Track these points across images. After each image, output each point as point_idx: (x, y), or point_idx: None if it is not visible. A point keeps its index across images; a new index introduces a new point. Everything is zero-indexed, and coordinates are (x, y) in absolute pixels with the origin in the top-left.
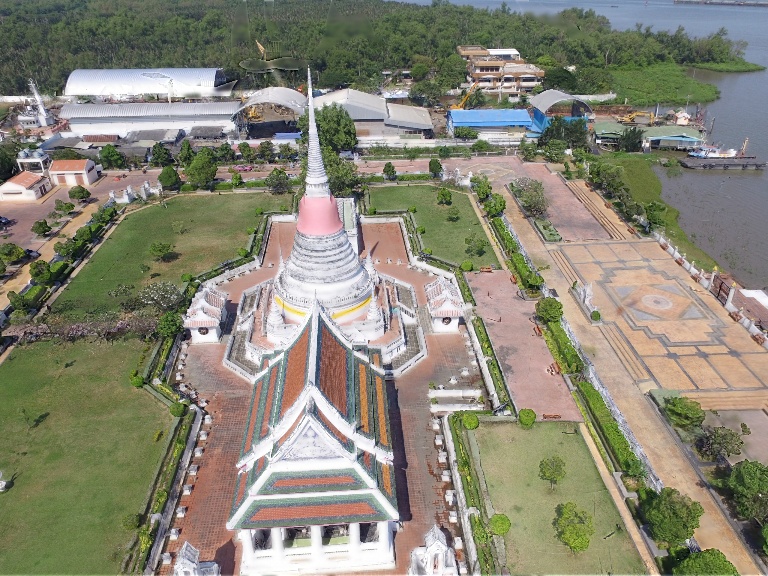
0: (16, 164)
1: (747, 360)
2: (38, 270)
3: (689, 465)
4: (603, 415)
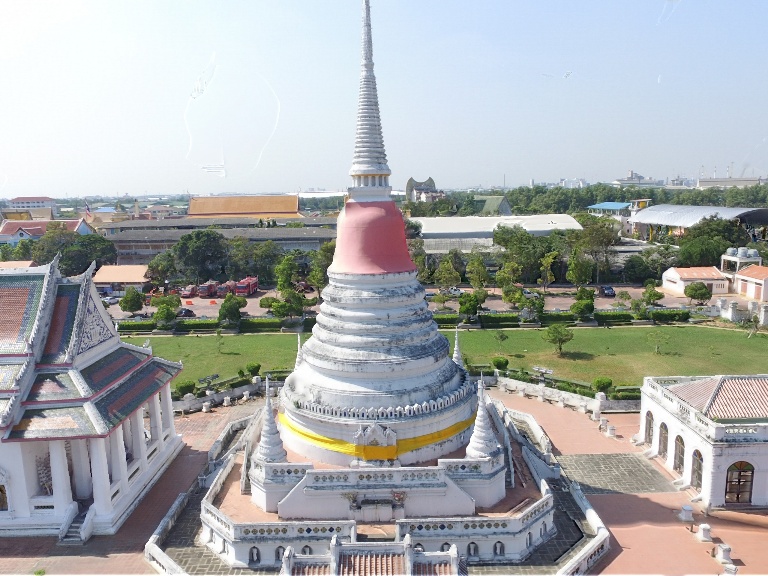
0: (721, 260)
1: None
2: (465, 301)
3: None
4: None
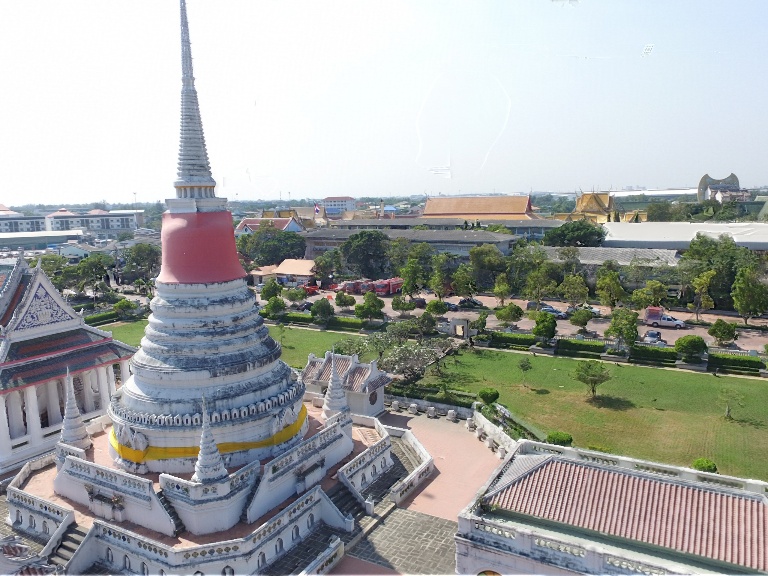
0: None
1: None
2: None
3: None
4: None
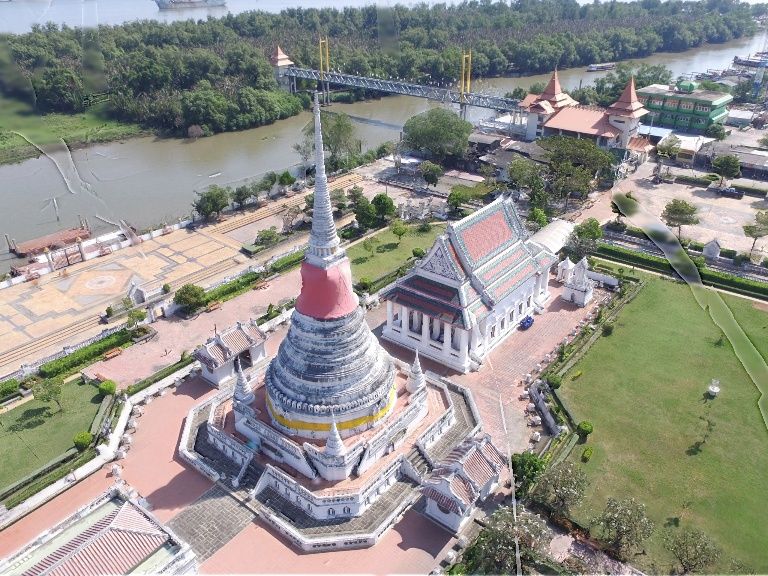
0: None
1: (171, 242)
2: None
3: (302, 237)
4: (300, 253)
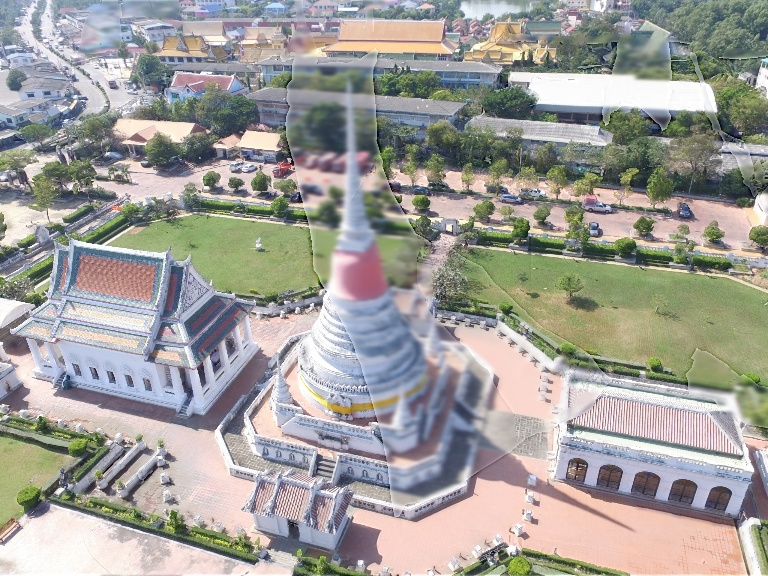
0: None
1: None
2: None
3: None
4: None
